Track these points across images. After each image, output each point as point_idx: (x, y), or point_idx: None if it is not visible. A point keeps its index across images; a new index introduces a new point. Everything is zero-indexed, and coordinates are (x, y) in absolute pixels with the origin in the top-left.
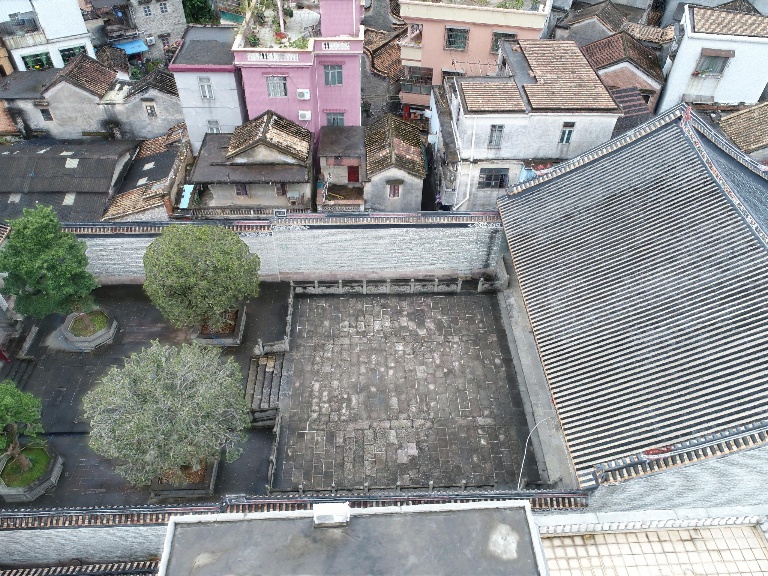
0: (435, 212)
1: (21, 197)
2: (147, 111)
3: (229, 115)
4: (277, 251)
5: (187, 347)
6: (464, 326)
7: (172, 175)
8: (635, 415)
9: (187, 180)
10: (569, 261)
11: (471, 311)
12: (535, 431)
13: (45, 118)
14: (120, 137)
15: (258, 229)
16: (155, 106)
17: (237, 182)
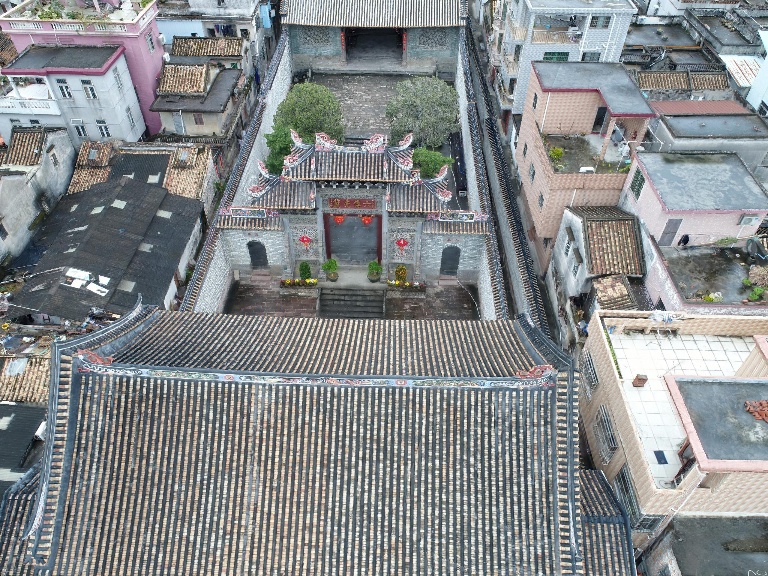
0: (279, 45)
1: (147, 243)
2: (52, 162)
3: (131, 95)
4: (268, 122)
5: (400, 87)
6: (336, 84)
7: (178, 143)
8: (442, 2)
9: (222, 109)
10: (351, 3)
11: (325, 81)
12: (407, 72)
13: (2, 238)
14: (48, 210)
15: (263, 108)
16: (55, 152)
17: (231, 93)
